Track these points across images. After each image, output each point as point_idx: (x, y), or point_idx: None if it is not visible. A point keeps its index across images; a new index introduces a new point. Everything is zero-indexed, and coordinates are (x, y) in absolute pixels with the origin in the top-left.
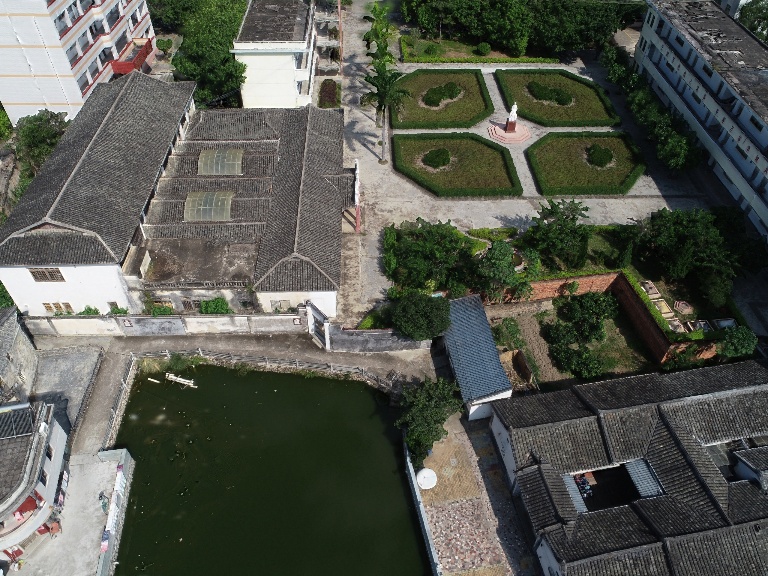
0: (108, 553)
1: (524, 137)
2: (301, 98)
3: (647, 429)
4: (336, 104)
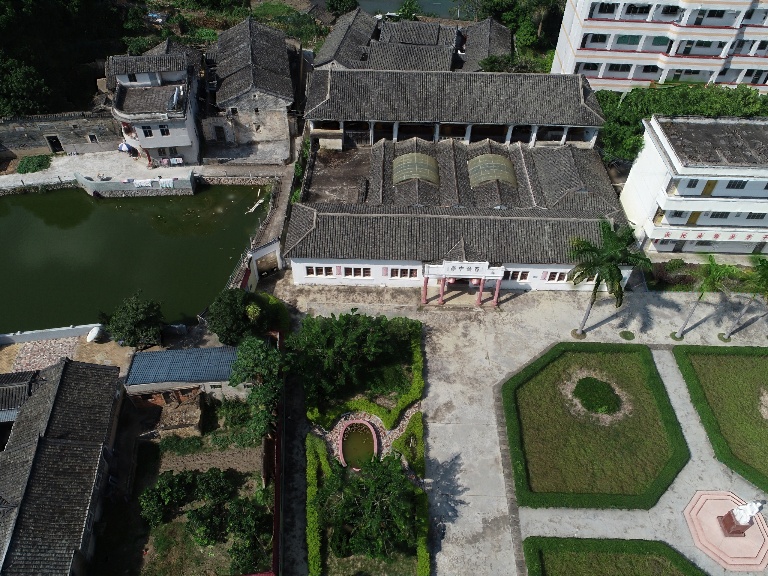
0: (124, 186)
1: (716, 552)
2: (650, 222)
3: (8, 490)
4: (713, 285)
